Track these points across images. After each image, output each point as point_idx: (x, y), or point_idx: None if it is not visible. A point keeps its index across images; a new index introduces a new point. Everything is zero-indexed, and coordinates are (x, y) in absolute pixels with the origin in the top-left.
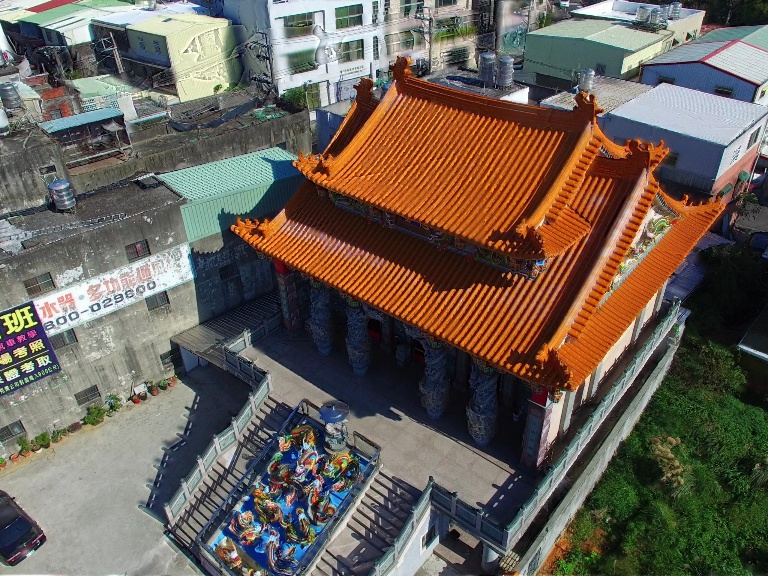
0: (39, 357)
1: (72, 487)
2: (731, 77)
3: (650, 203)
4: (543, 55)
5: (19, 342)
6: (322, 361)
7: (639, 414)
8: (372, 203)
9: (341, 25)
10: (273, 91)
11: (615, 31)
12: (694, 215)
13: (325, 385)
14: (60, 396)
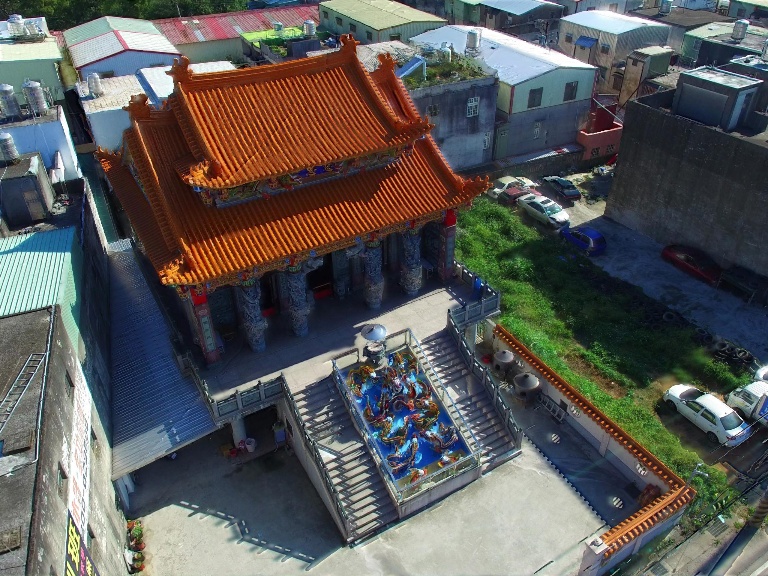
0: None
1: None
2: (158, 54)
3: None
4: None
5: (83, 575)
6: (271, 353)
7: None
8: (288, 170)
9: None
10: None
11: (9, 49)
12: None
13: (303, 357)
14: None
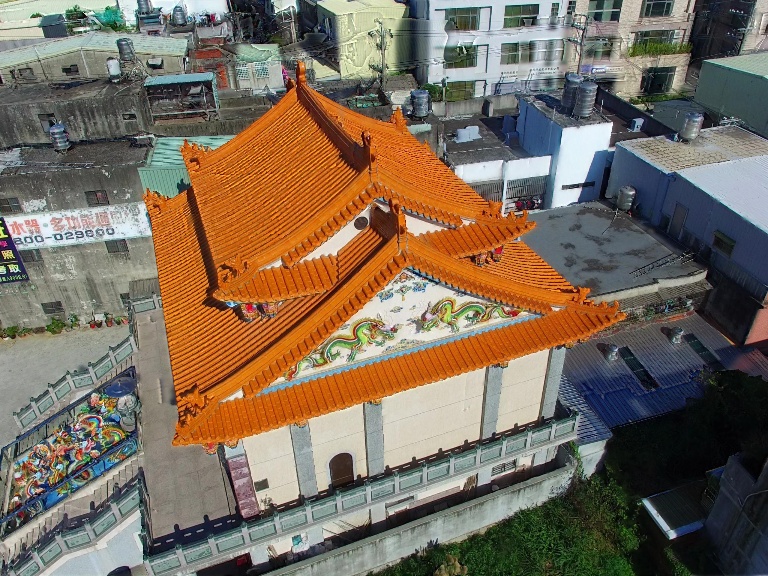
0: (11, 264)
1: (0, 374)
2: None
3: (390, 276)
4: (716, 89)
5: None
6: None
7: (484, 525)
8: None
9: (510, 24)
10: (378, 81)
11: None
12: (580, 315)
13: None
14: (29, 301)
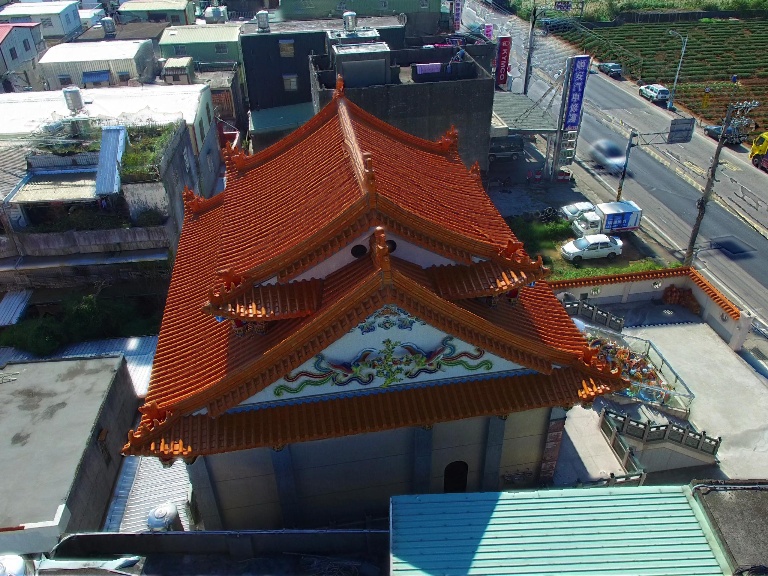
0: None
1: None
2: None
3: None
4: None
5: None
6: None
7: None
8: None
9: None
10: None
11: None
12: None
13: None
14: None
